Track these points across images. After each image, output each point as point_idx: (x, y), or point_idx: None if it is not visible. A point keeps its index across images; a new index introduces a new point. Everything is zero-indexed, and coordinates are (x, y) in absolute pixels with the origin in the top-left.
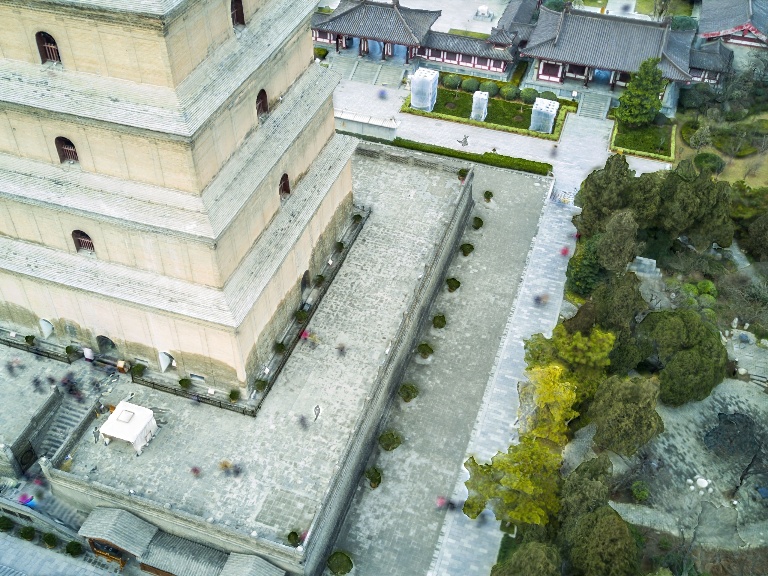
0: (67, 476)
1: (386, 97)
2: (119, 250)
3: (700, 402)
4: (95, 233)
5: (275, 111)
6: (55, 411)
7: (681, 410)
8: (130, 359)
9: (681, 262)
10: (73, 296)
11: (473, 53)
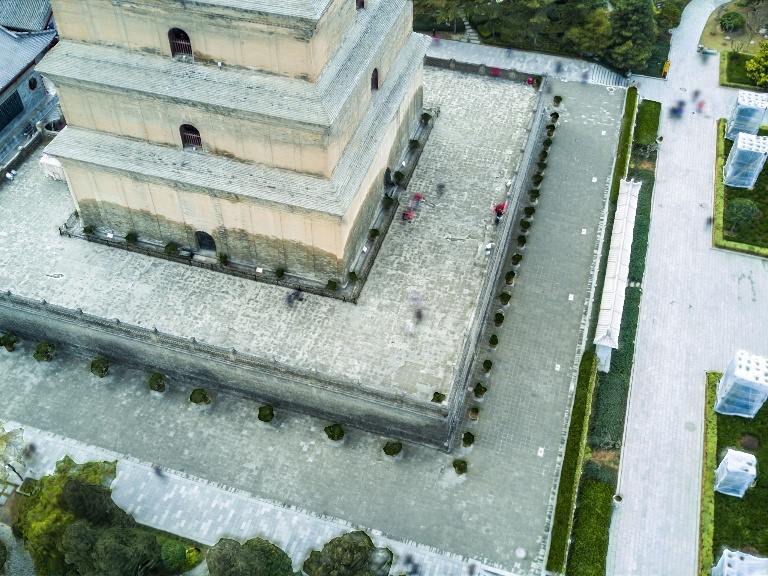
0: None
1: None
2: None
3: None
4: None
5: (206, 67)
6: None
7: None
8: None
9: None
10: None
11: None
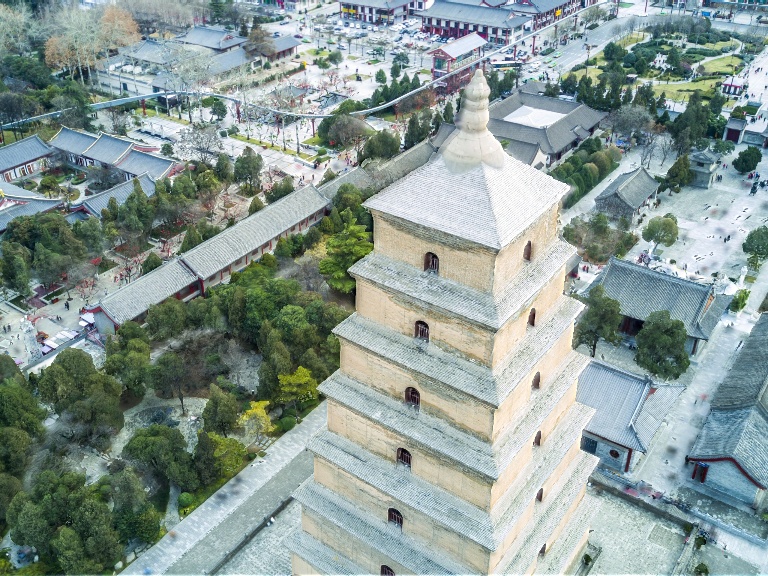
0: None
1: None
2: None
3: None
4: None
5: None
6: None
7: None
8: None
9: None
10: None
11: None
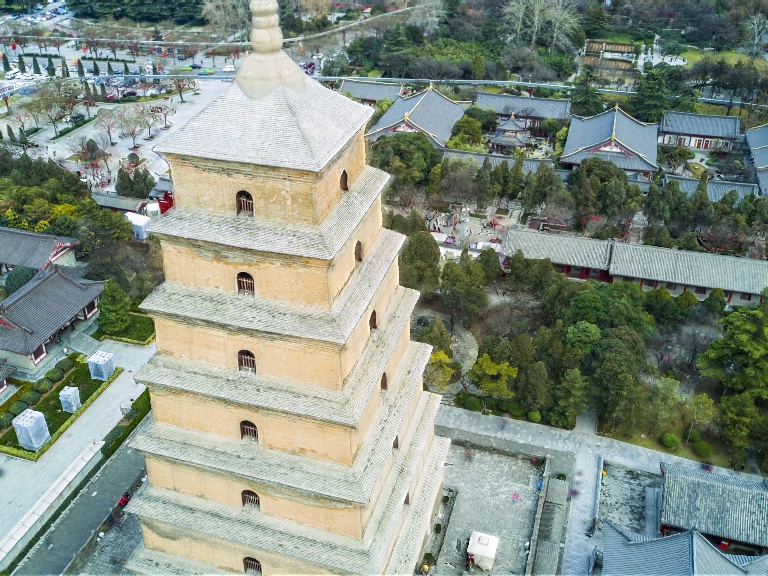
0: None
1: (3, 471)
2: None
3: None
4: None
5: None
6: None
7: None
8: (421, 562)
9: None
10: None
11: None
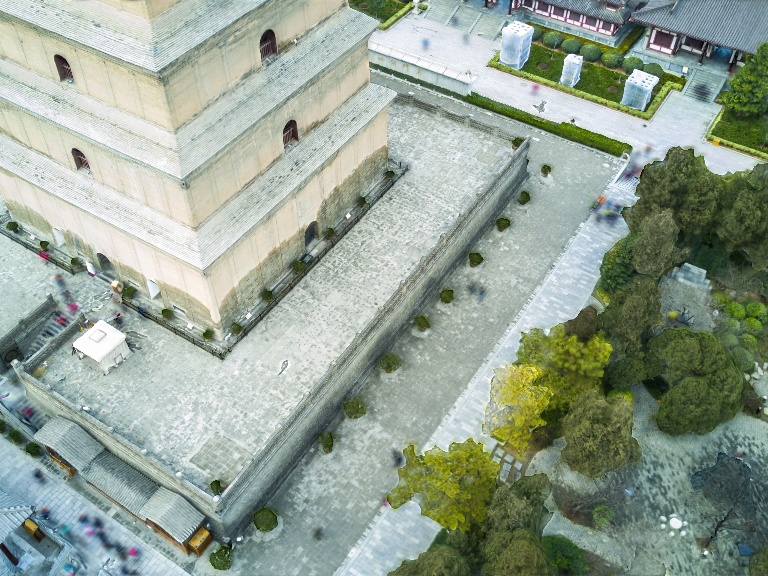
0: (34, 381)
1: (477, 48)
2: (109, 174)
3: (706, 435)
4: (89, 154)
5: (287, 54)
6: (47, 317)
7: (682, 440)
8: (125, 280)
9: (732, 278)
10: (74, 211)
11: (581, 11)
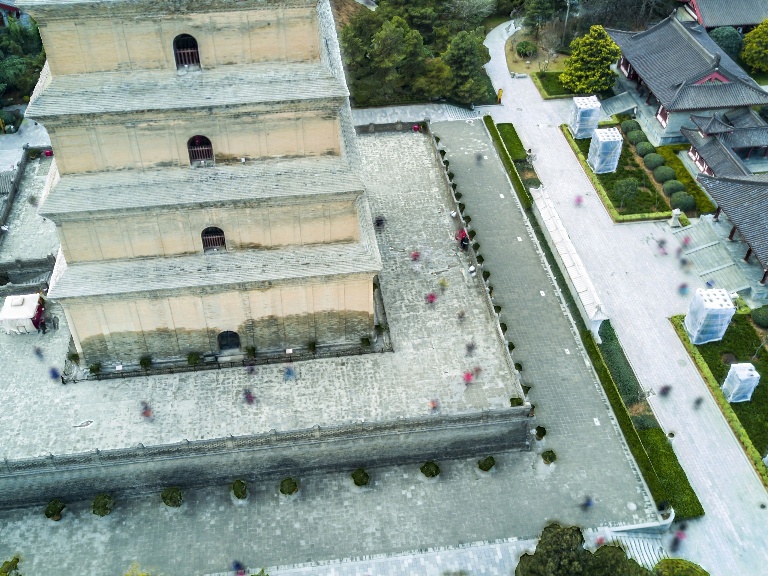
0: None
1: (685, 295)
2: None
3: None
4: None
5: (228, 166)
6: (44, 271)
7: None
8: None
9: None
10: None
11: None
